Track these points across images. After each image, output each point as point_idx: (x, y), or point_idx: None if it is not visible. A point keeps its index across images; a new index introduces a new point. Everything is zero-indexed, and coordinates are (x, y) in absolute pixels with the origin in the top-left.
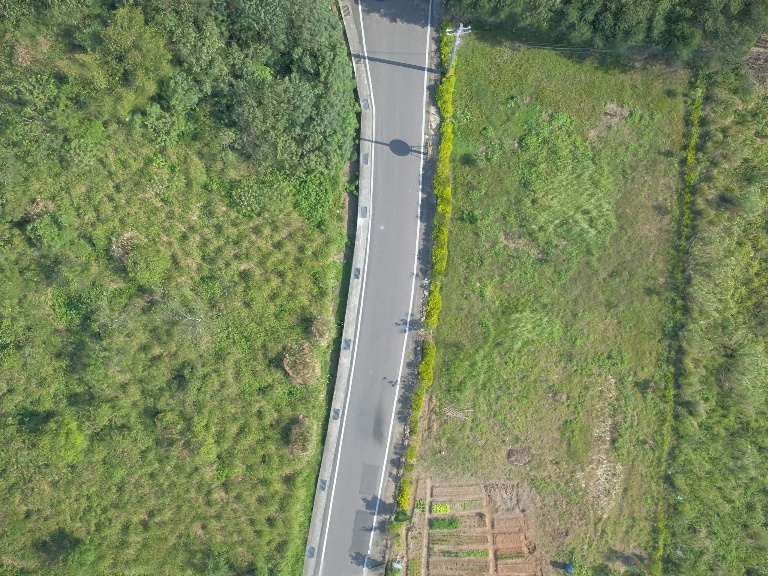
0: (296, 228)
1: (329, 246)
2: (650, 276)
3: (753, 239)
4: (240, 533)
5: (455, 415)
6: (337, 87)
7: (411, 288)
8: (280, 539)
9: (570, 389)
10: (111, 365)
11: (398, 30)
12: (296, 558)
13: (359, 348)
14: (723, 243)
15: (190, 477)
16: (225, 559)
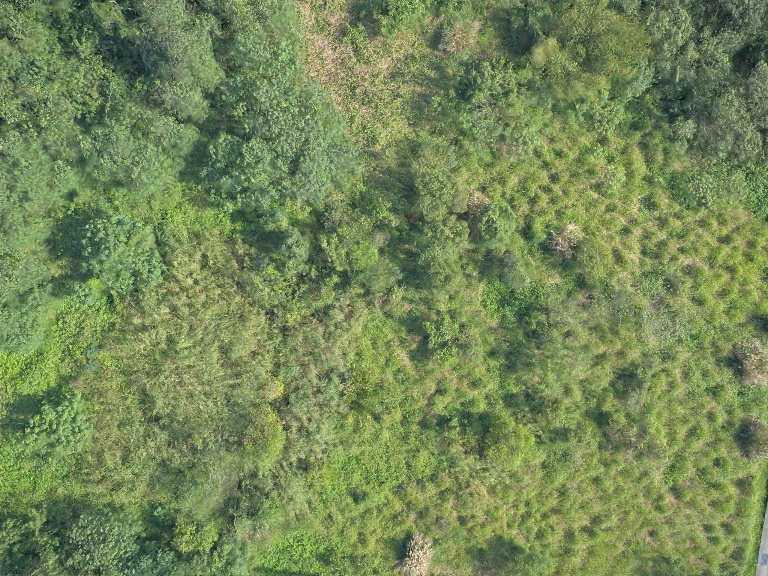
0: (744, 221)
1: None
2: None
3: None
4: (695, 540)
5: None
6: None
7: None
8: (734, 546)
9: None
10: (575, 364)
11: None
12: (748, 565)
13: None
14: None
15: (639, 481)
16: None
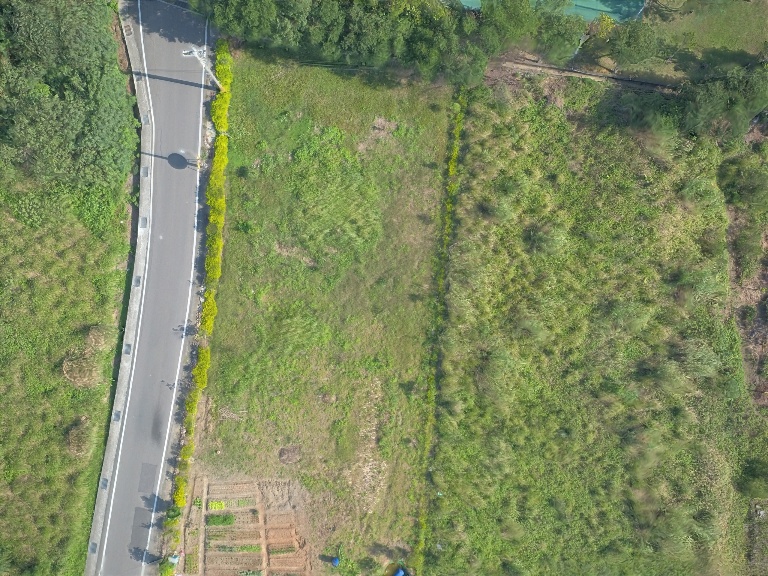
0: (79, 238)
1: (111, 255)
2: (415, 282)
3: (509, 247)
4: (24, 530)
5: (230, 416)
6: (109, 104)
7: (188, 295)
8: (62, 535)
9: (338, 391)
10: None
11: (176, 49)
12: (79, 554)
13: (139, 353)
14: (479, 251)
15: None
16: (10, 555)
